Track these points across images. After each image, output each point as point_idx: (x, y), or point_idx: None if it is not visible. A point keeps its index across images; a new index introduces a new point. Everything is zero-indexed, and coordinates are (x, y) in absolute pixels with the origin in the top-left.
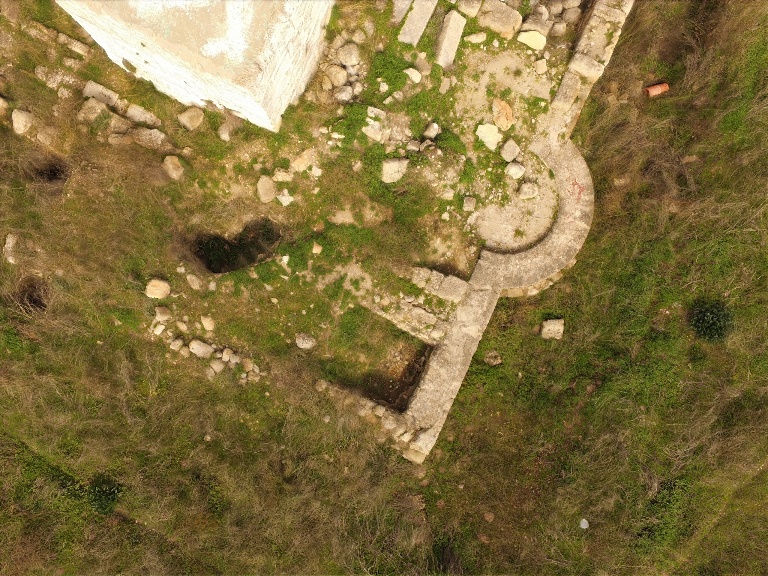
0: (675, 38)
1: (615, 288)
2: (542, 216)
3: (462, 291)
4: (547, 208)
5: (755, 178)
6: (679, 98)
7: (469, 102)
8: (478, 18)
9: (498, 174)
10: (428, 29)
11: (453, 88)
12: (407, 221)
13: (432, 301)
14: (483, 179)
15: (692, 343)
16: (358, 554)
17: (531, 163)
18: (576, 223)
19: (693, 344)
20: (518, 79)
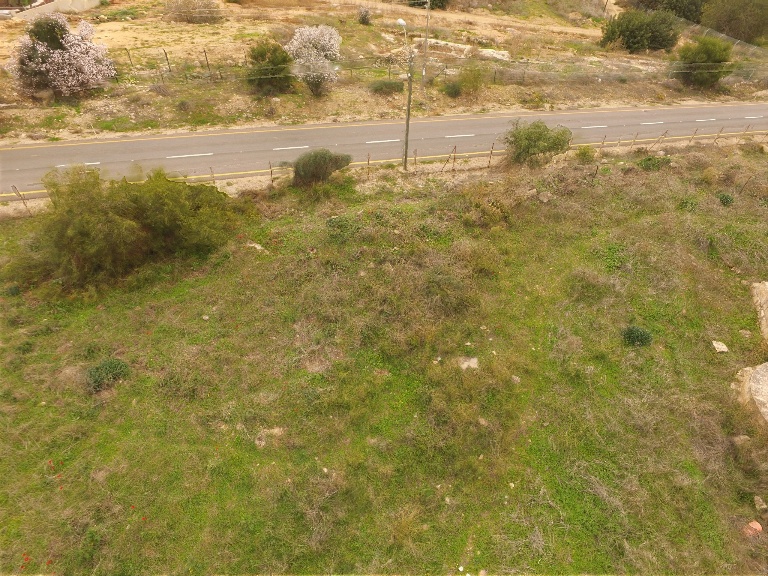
0: None
1: None
2: None
3: None
4: None
5: None
6: None
7: None
8: None
9: None
10: None
11: None
12: None
13: None
14: None
15: None
16: (763, 247)
17: None
18: (766, 400)
19: None
20: None
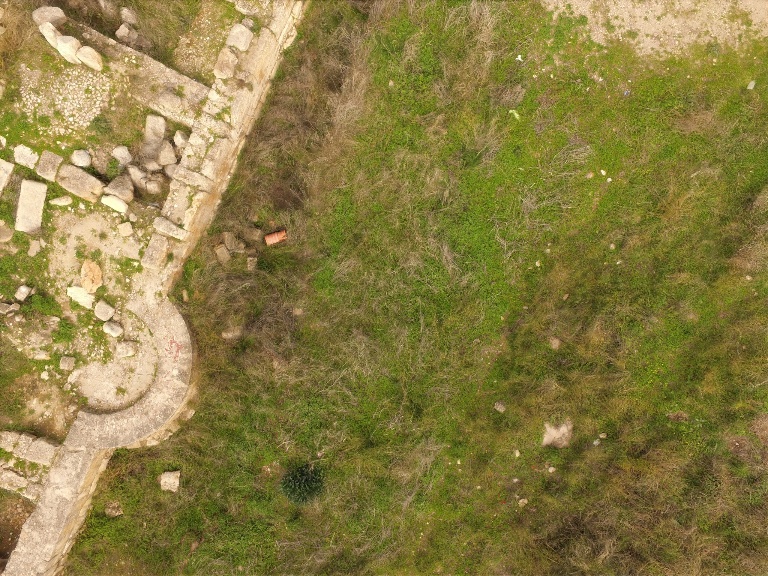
0: (287, 188)
1: (222, 443)
2: (144, 373)
3: (49, 455)
4: (149, 365)
5: (338, 340)
6: (285, 251)
7: (60, 263)
8: (58, 183)
9: (99, 331)
10: (4, 196)
11: (44, 250)
12: (1, 383)
13: (25, 463)
14: (85, 336)
15: (287, 503)
16: None
17: (131, 320)
18: (174, 381)
19: (288, 504)
20: (104, 241)
